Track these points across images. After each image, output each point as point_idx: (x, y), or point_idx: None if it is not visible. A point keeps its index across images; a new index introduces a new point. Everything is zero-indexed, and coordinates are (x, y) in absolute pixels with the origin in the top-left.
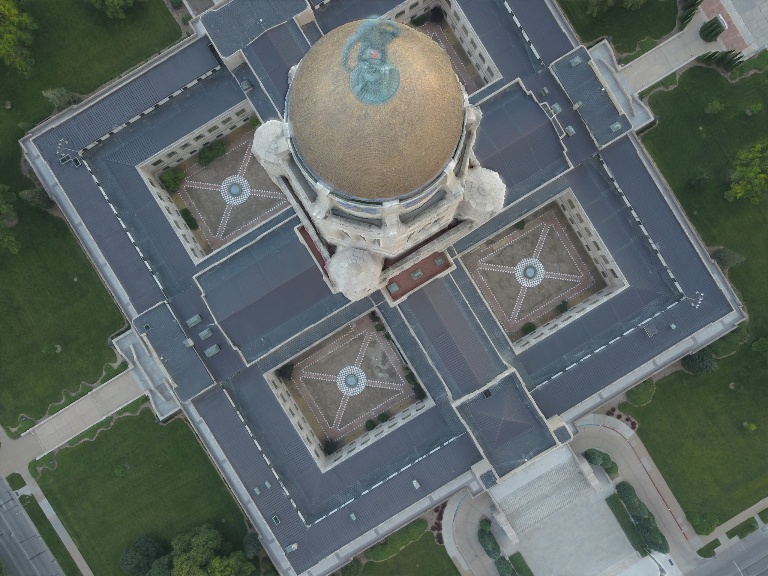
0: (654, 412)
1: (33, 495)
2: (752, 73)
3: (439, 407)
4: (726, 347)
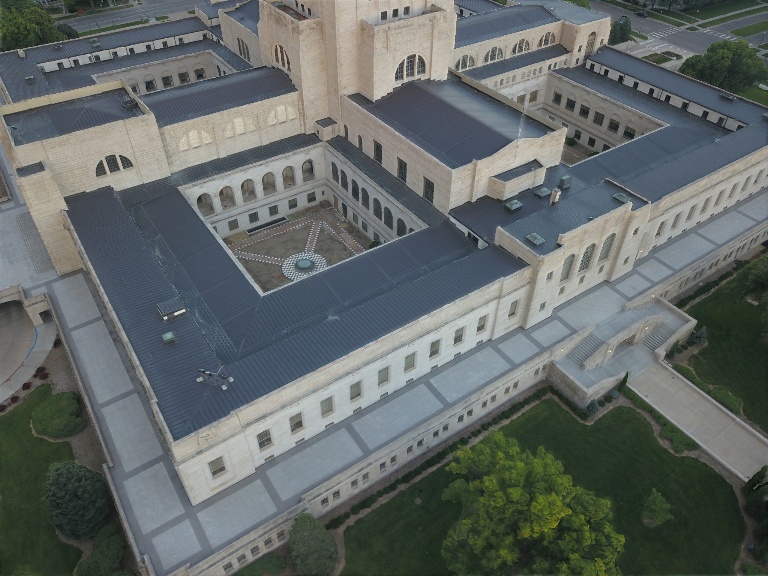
0: (8, 443)
1: (148, 23)
2: None
3: None
4: (97, 575)
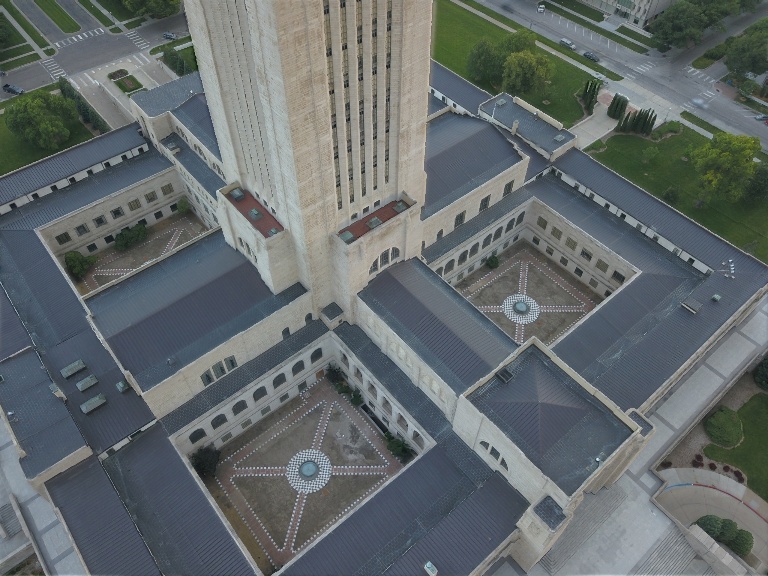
0: (757, 453)
1: None
2: (670, 135)
3: (443, 448)
4: None
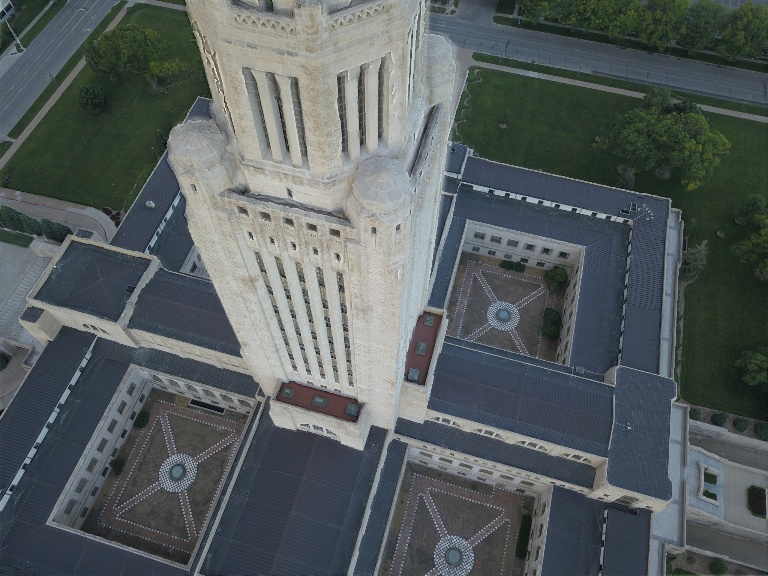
0: None
1: None
2: None
3: None
4: None
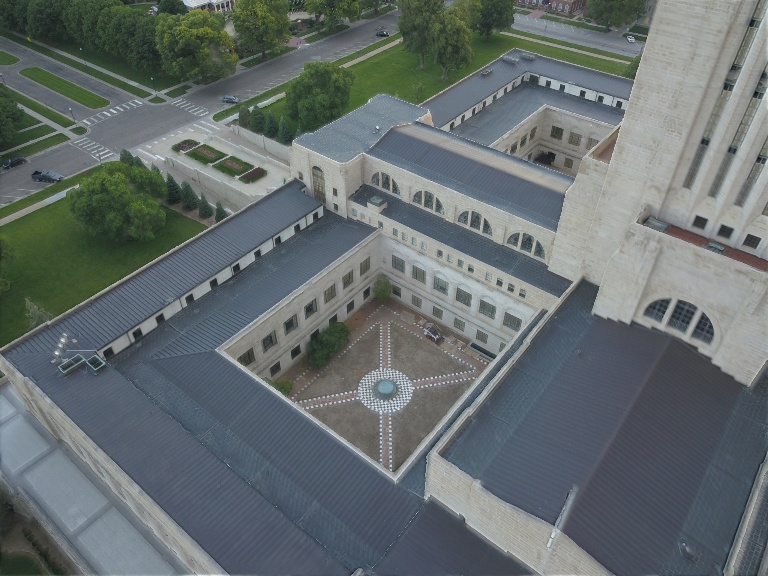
0: None
1: None
2: None
3: None
4: None
